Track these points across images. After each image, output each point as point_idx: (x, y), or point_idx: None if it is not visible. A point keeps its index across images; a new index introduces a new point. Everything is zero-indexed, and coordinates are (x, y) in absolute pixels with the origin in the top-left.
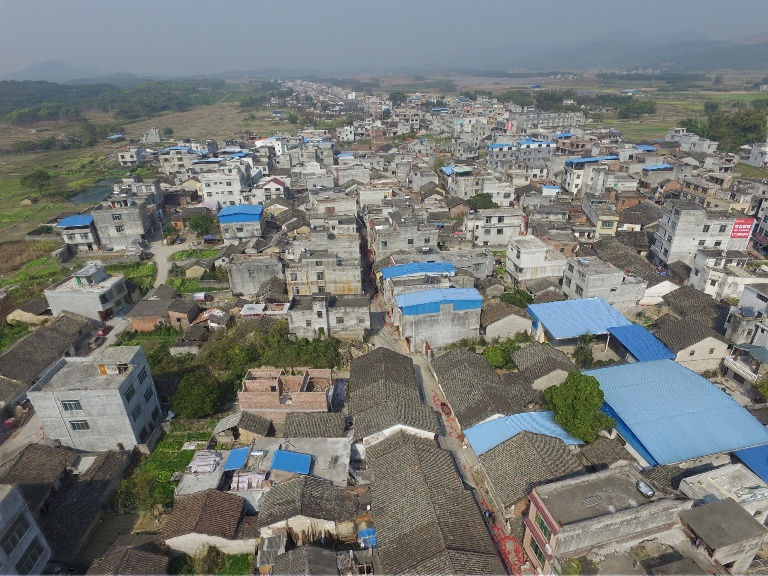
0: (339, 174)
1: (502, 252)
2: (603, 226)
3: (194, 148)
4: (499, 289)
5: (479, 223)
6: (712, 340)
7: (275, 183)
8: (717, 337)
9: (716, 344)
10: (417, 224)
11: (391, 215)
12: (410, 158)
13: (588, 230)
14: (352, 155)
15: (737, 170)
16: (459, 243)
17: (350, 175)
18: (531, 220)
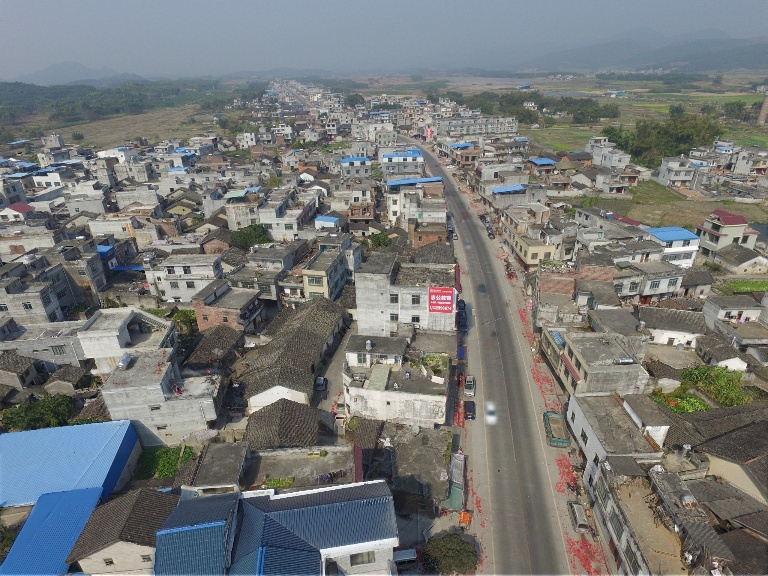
0: (117, 196)
1: (193, 312)
2: (310, 282)
3: (40, 159)
4: (65, 386)
5: (160, 274)
6: (133, 544)
7: (11, 209)
8: (132, 542)
9: (147, 549)
10: (7, 285)
11: (1, 268)
12: (242, 174)
13: (296, 286)
14: (184, 170)
15: (638, 190)
16: (139, 299)
17: (132, 197)
18: (242, 269)
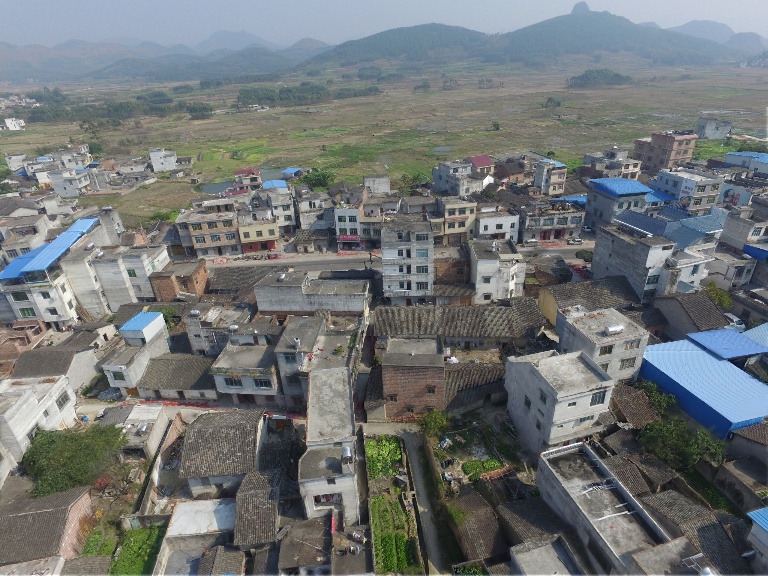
0: None
1: (375, 457)
2: None
3: None
4: None
5: None
6: None
7: None
8: None
9: None
10: None
11: None
12: None
13: None
14: None
15: None
16: None
17: None
18: None
